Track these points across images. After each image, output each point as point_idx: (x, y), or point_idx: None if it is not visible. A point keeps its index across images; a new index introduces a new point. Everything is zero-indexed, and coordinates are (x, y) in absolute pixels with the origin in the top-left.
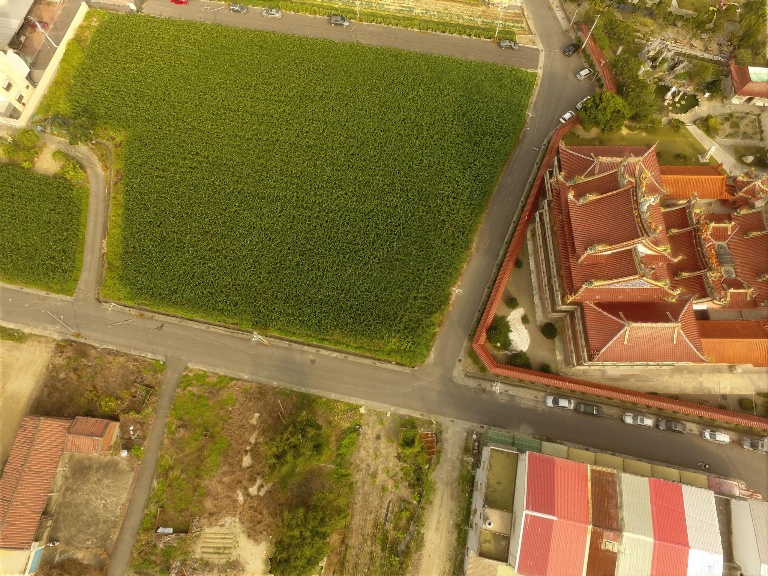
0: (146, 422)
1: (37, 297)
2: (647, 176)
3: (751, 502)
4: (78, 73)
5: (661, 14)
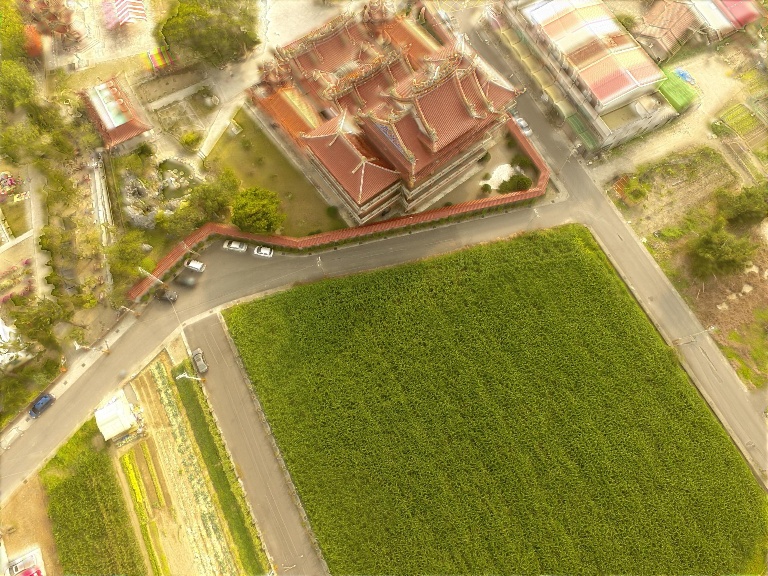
0: None
1: None
2: None
3: None
4: None
5: None
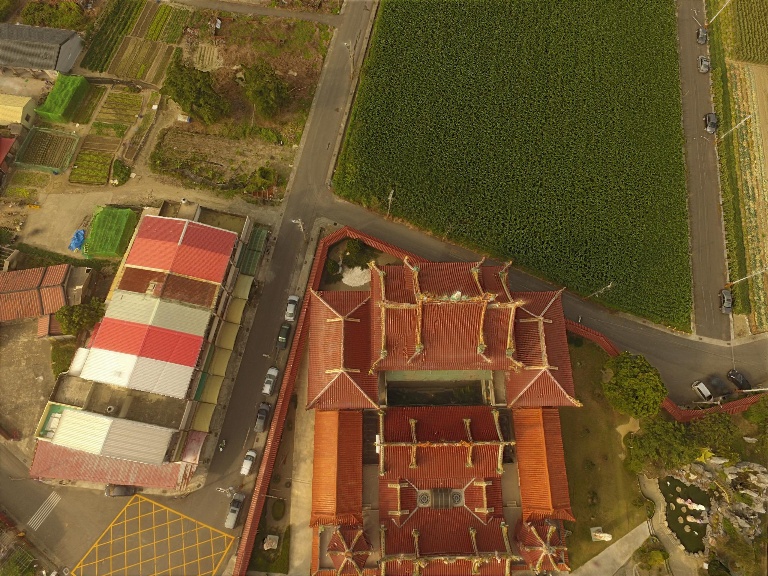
0: (294, 6)
1: None
2: None
3: (169, 432)
4: None
5: None
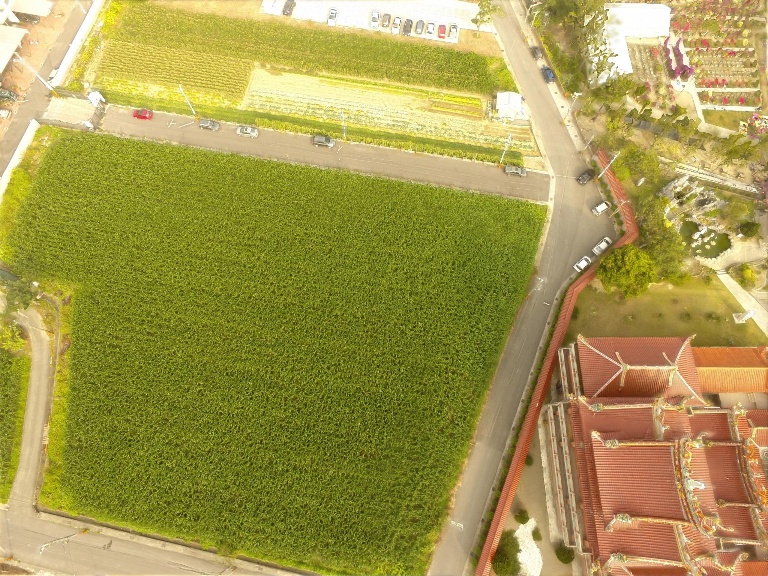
0: None
1: None
2: (694, 446)
3: None
4: (23, 210)
5: (687, 136)
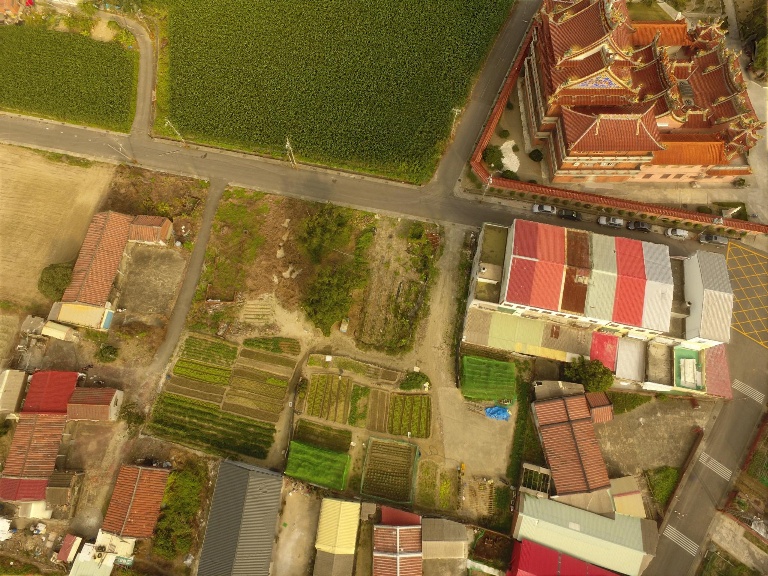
0: (195, 223)
1: (98, 134)
2: None
3: (698, 252)
4: None
5: None
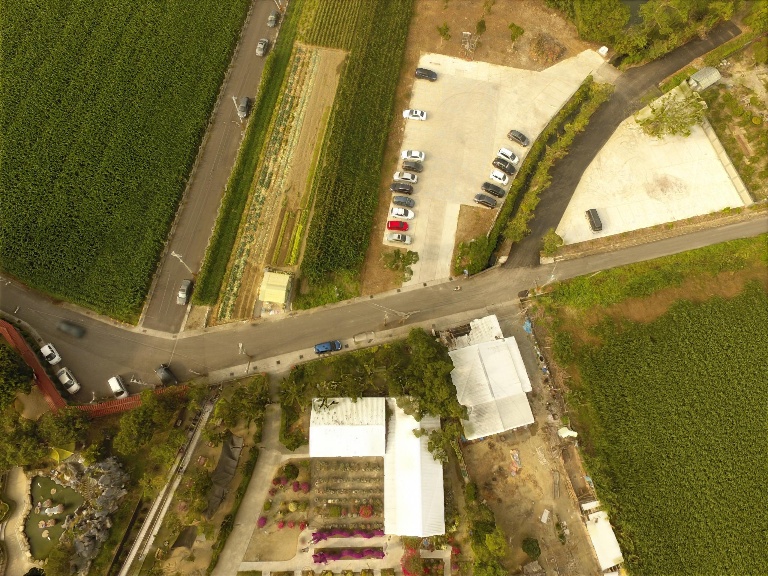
0: None
1: None
2: None
3: None
4: None
5: None
